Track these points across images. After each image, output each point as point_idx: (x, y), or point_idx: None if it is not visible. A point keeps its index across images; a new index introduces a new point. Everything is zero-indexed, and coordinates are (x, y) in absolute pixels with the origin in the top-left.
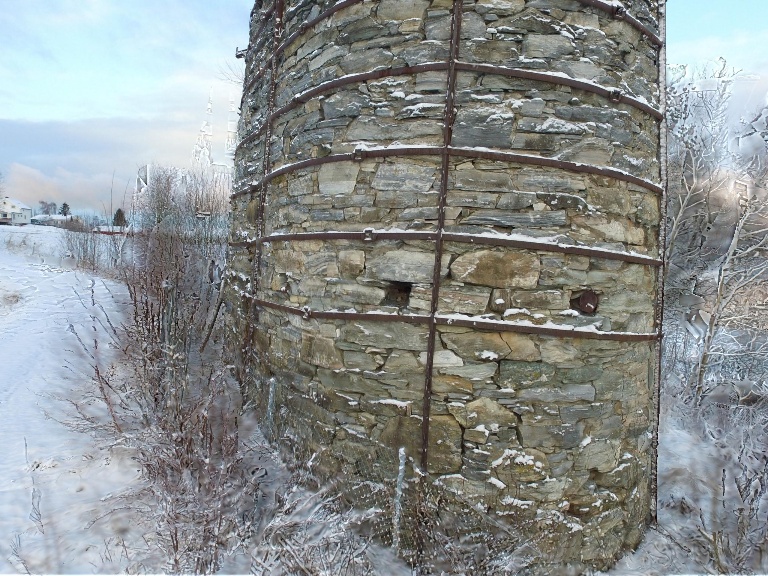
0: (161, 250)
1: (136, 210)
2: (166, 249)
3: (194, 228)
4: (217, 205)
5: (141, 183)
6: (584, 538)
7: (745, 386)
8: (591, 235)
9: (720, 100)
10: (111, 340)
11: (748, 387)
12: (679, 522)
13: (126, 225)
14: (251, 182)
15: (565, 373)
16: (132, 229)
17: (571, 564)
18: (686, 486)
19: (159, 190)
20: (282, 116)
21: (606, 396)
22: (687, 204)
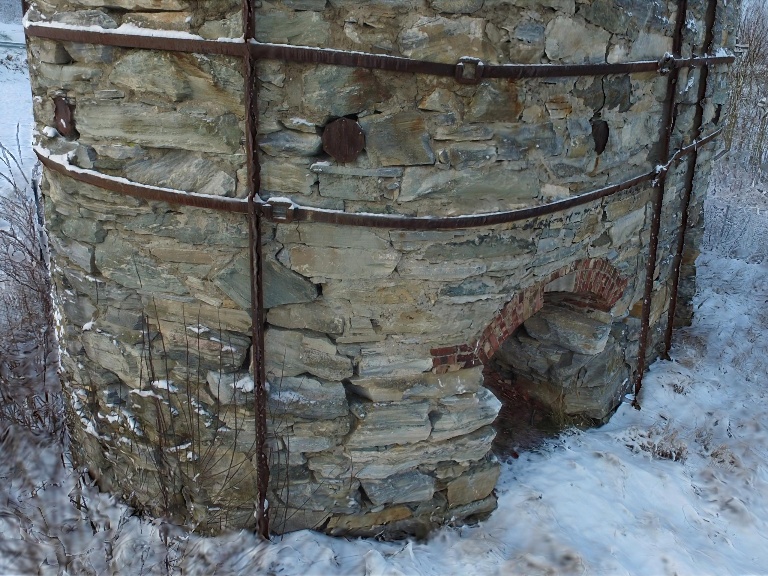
0: None
1: None
2: None
3: None
4: (760, 33)
5: None
6: (106, 451)
7: None
8: (53, 1)
9: None
10: None
11: None
12: (269, 555)
13: None
14: None
15: (64, 221)
16: None
17: (103, 472)
18: (509, 574)
19: None
20: None
21: (104, 272)
22: None
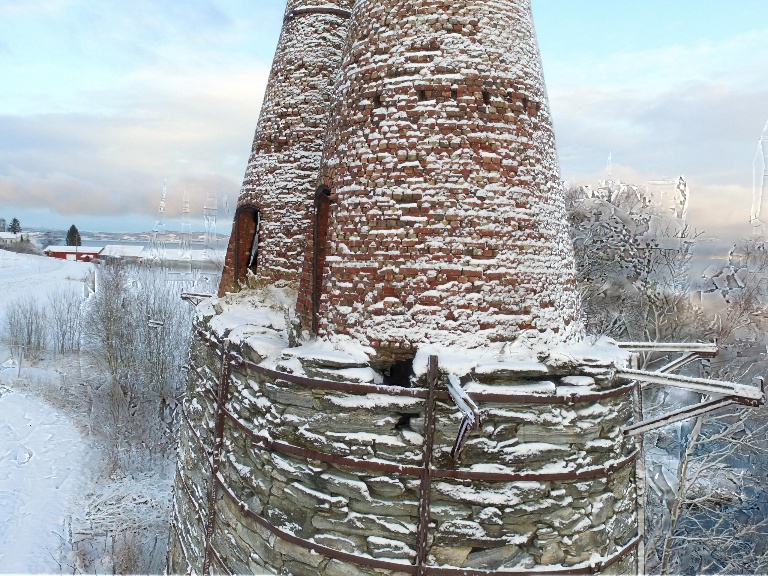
0: (106, 413)
1: (83, 320)
2: (111, 412)
3: (145, 339)
4: (170, 315)
5: (88, 289)
6: None
7: (707, 556)
8: None
9: (682, 260)
10: (45, 568)
11: (710, 557)
12: None
13: (72, 338)
14: (190, 571)
15: None
16: (78, 341)
17: None
18: None
19: (108, 297)
20: (221, 569)
21: None
22: (650, 359)
